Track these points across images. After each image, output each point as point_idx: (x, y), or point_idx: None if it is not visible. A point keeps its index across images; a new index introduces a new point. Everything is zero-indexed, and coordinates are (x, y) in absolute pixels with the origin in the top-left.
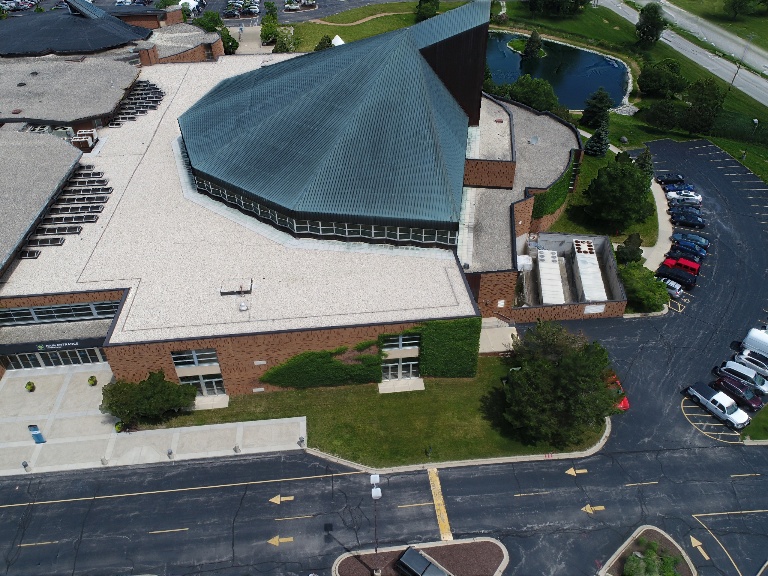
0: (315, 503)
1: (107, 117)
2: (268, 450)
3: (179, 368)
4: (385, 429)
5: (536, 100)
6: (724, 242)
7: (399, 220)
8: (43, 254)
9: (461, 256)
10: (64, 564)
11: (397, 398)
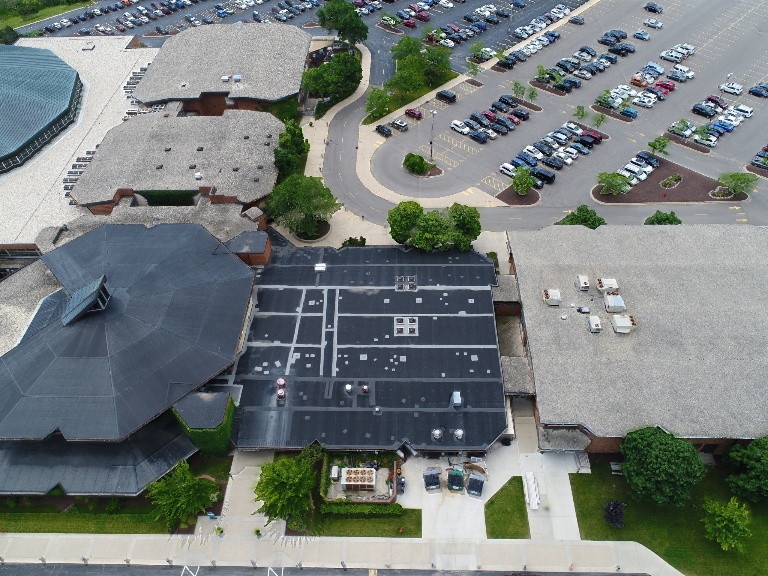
0: None
1: None
2: None
3: None
4: None
5: None
6: None
7: None
8: None
9: None
10: (165, 38)
11: None
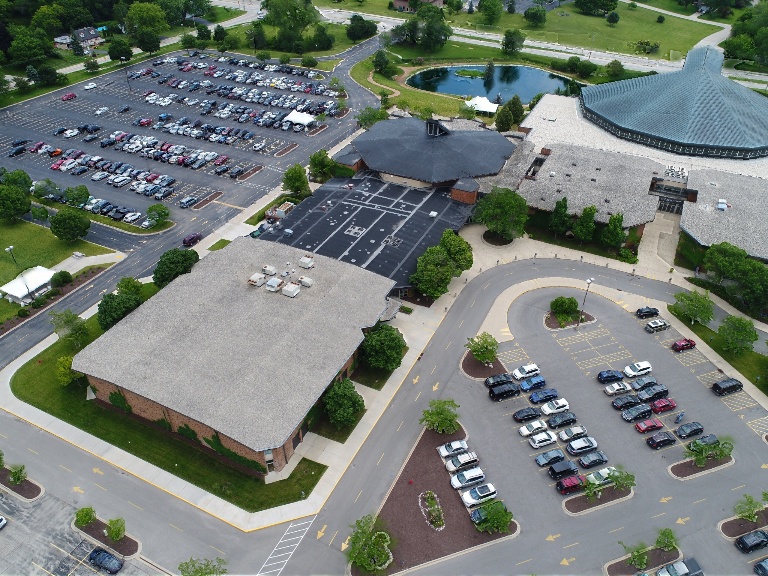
0: None
1: None
2: None
3: None
4: None
5: None
6: None
7: None
8: None
9: None
10: None
11: None
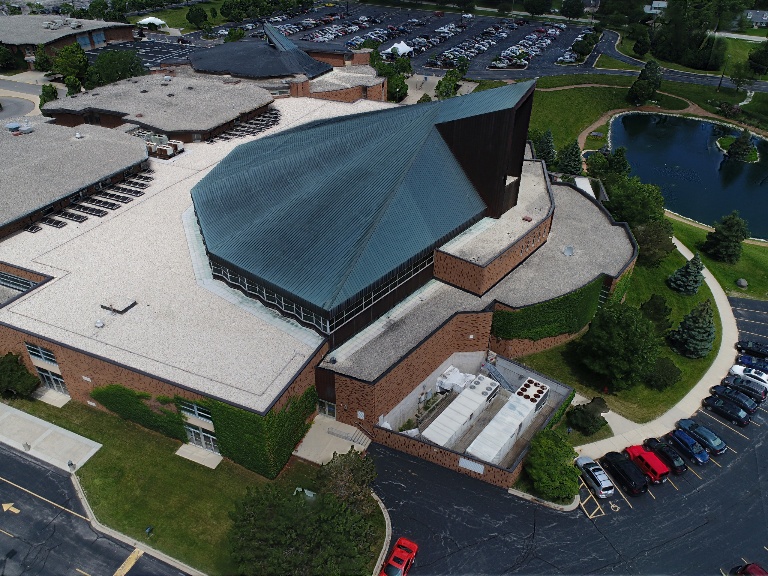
0: (27, 526)
1: (209, 134)
2: (47, 460)
3: (33, 357)
4: (144, 489)
5: (628, 207)
6: (757, 456)
7: (282, 290)
8: (42, 231)
9: (343, 348)
10: None
11: (183, 465)
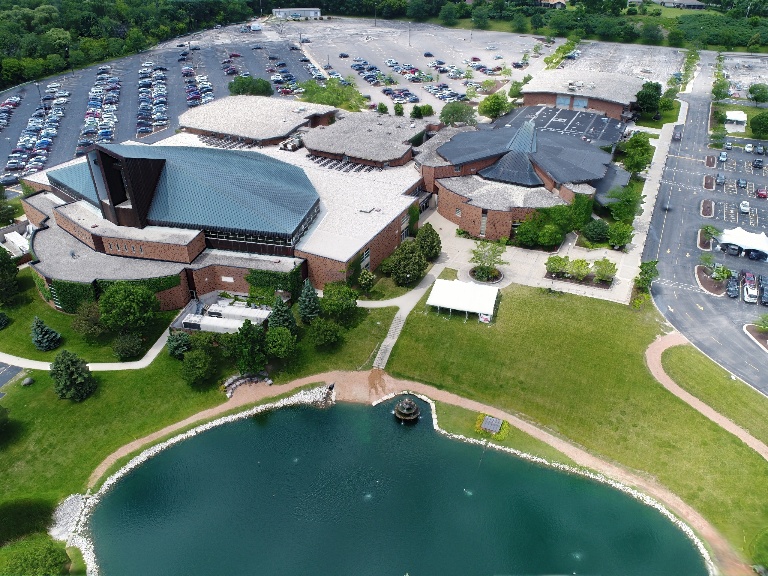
0: None
1: (316, 152)
2: None
3: None
4: None
5: None
6: None
7: None
8: None
9: None
10: None
11: None
